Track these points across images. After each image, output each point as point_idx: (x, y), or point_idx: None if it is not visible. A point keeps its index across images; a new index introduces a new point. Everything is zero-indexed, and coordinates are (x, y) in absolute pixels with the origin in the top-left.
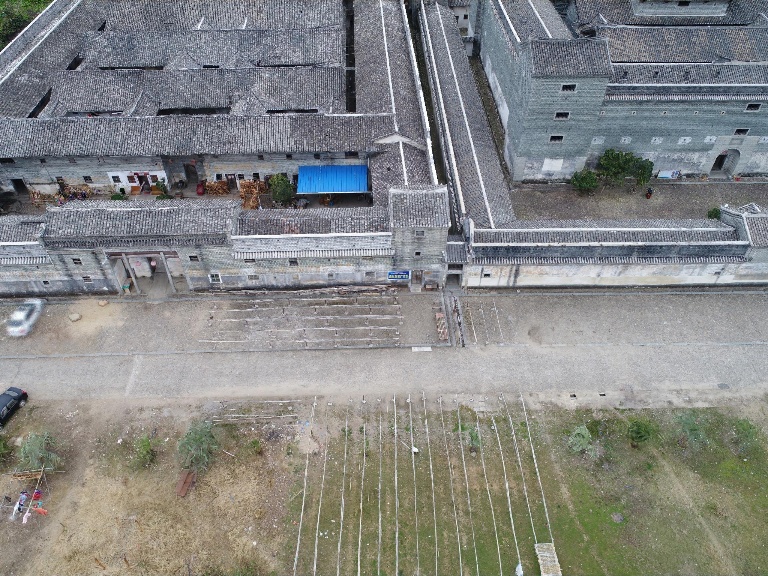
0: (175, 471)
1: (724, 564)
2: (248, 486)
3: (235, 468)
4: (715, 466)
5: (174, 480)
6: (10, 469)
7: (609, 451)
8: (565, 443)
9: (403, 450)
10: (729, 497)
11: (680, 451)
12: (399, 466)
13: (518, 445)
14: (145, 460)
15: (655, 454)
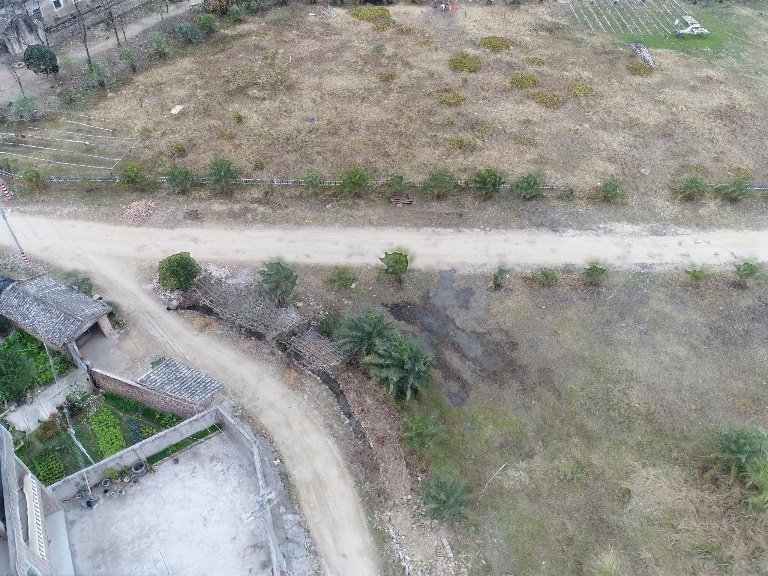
0: (504, 6)
1: (767, 25)
2: (541, 9)
3: (532, 5)
4: (761, 7)
5: (505, 8)
6: (425, 5)
7: (709, 4)
8: (687, 2)
9: (609, 3)
10: (767, 13)
11: (743, 4)
12: (609, 6)
13: (664, 2)
14: (487, 4)
15: (731, 5)
